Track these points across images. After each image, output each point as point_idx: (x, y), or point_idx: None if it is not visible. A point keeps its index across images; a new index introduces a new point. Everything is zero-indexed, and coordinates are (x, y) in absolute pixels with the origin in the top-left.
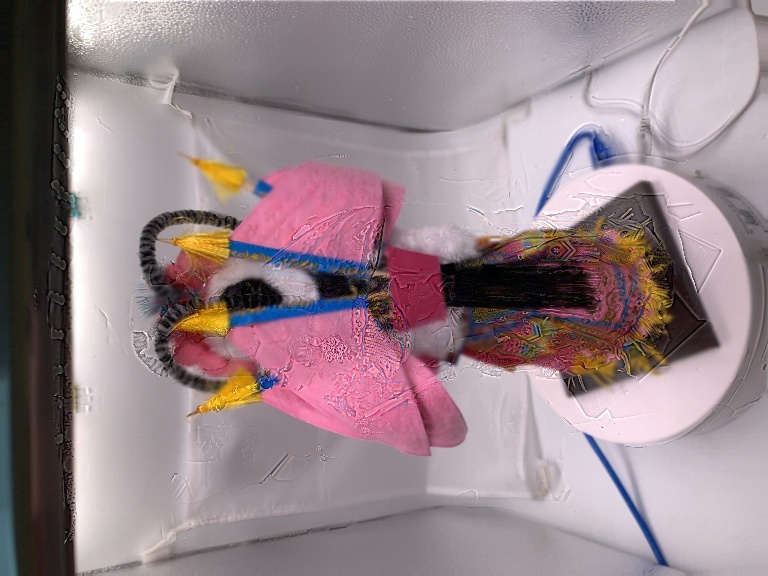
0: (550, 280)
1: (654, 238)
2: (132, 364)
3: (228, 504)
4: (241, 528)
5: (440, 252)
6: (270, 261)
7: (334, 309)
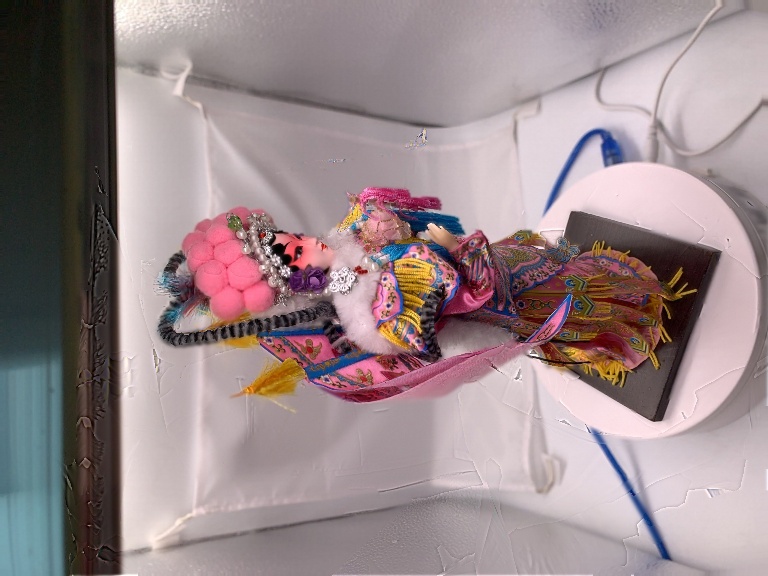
0: None
1: None
2: (173, 357)
3: None
4: None
5: None
6: None
7: None
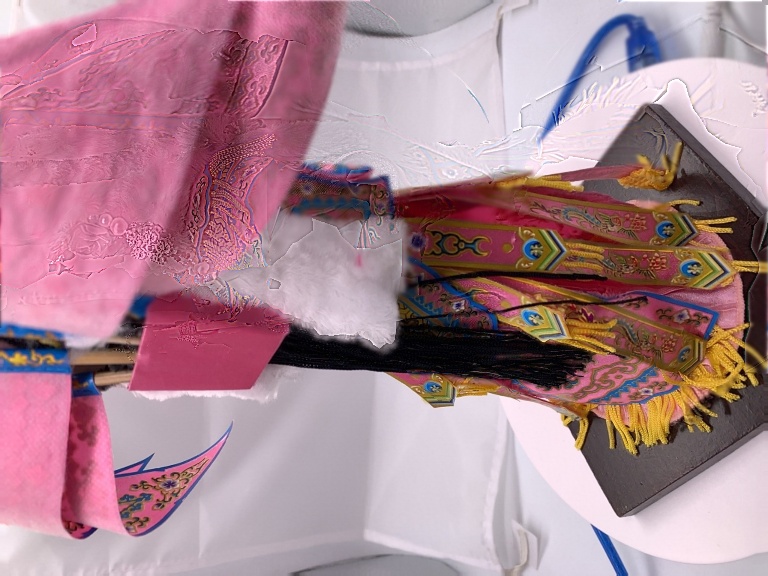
0: (501, 349)
1: (740, 307)
2: None
3: (75, 282)
4: (94, 305)
5: (267, 300)
6: (1, 98)
7: (155, 184)
